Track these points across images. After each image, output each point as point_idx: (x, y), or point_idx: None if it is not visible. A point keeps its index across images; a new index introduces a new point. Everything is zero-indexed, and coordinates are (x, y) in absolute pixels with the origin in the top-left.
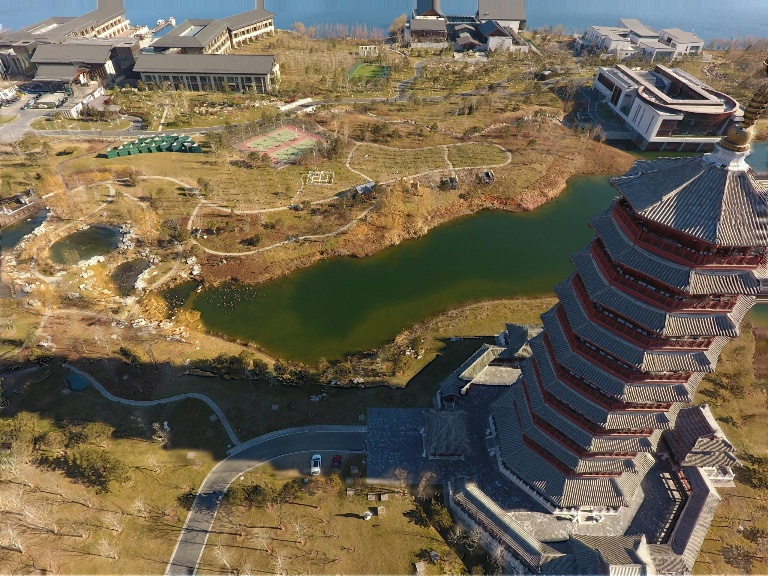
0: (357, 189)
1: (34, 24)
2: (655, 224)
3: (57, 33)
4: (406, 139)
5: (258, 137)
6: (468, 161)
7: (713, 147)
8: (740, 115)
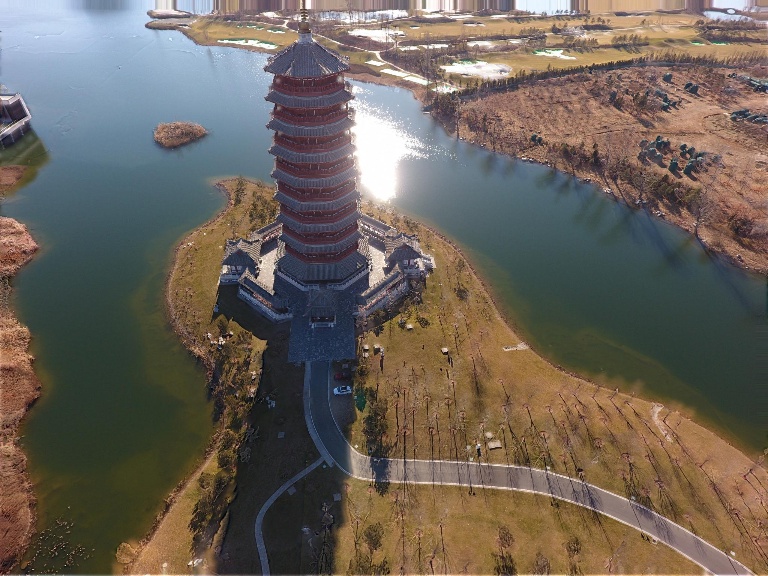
0: None
1: None
2: (321, 80)
3: None
4: None
5: None
6: None
7: (18, 133)
8: (8, 98)
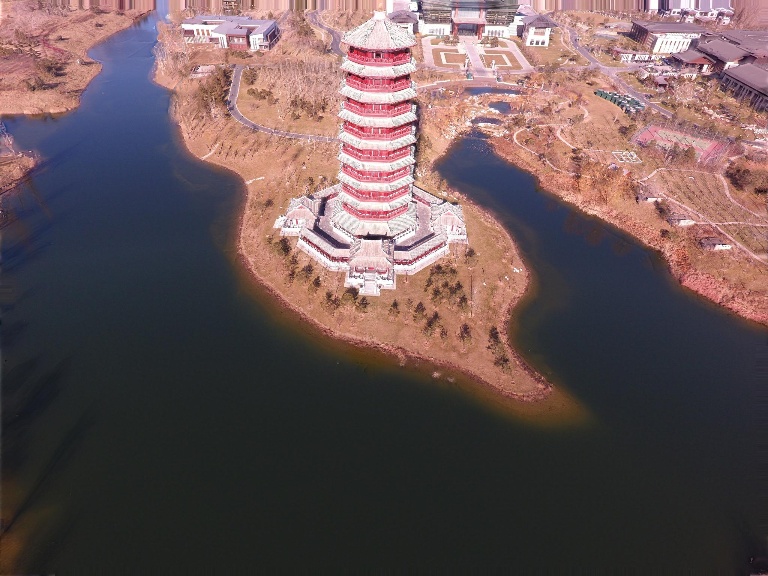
0: (612, 165)
1: (766, 33)
2: None
3: (766, 43)
4: (759, 200)
5: (678, 133)
6: (744, 236)
7: None
8: None
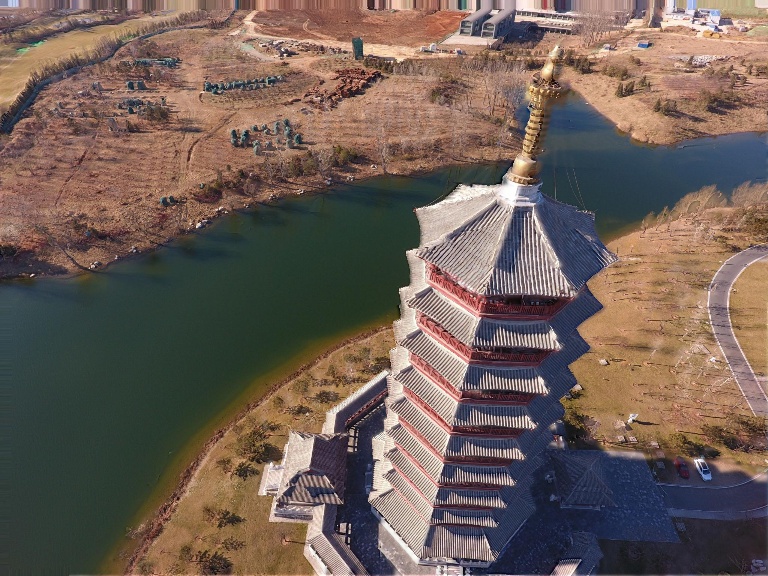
0: None
1: None
2: None
3: None
4: None
5: None
6: None
7: None
8: None
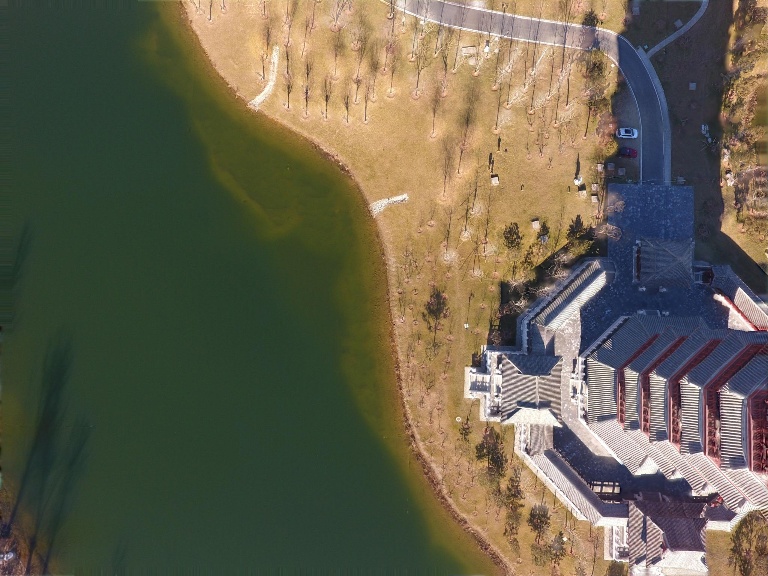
0: None
1: None
2: None
3: None
4: None
5: None
6: None
7: None
8: None
